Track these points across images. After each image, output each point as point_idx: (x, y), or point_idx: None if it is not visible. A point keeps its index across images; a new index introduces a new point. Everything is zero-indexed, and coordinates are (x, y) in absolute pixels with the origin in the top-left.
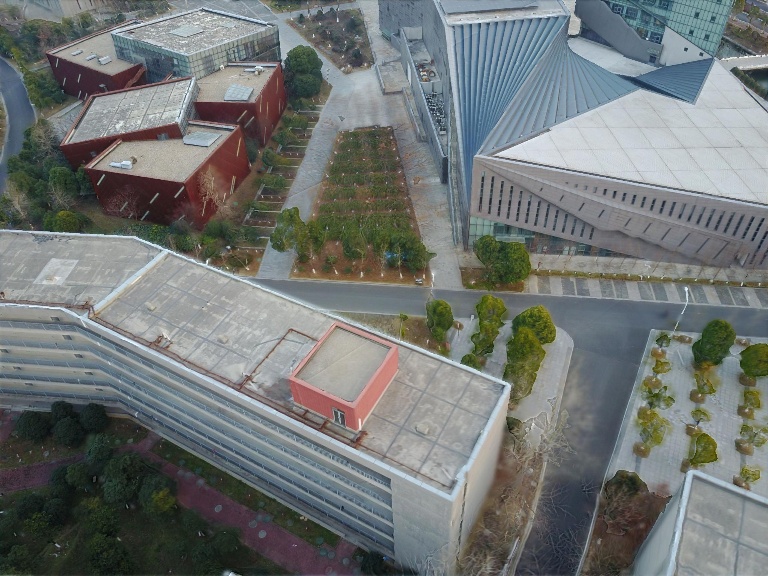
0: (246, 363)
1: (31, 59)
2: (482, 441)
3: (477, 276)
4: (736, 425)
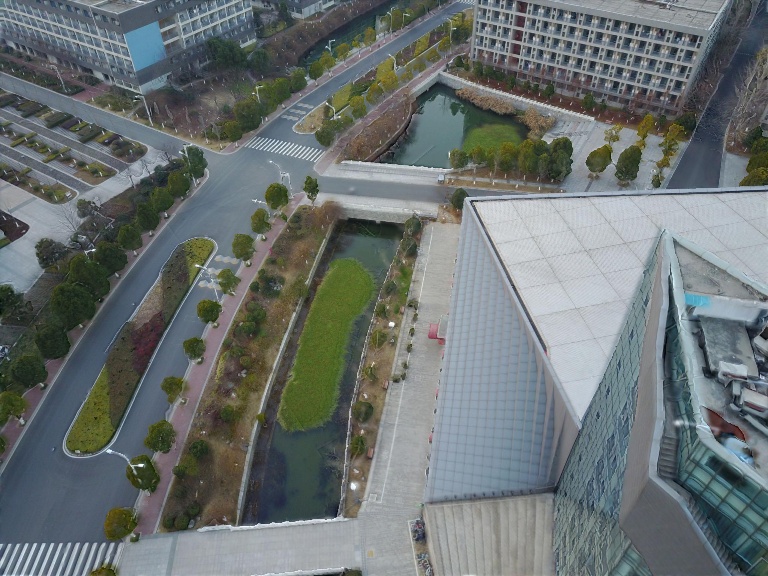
0: None
1: None
2: None
3: None
4: None
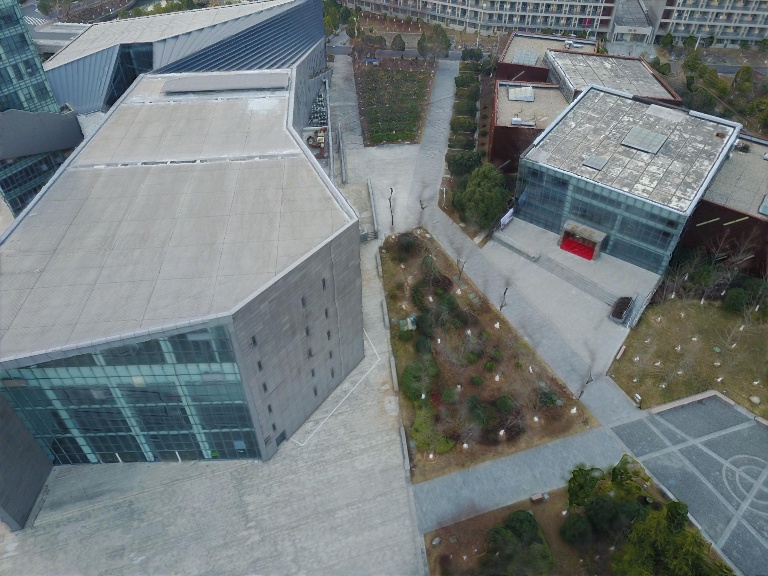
0: None
1: None
2: None
3: None
4: None
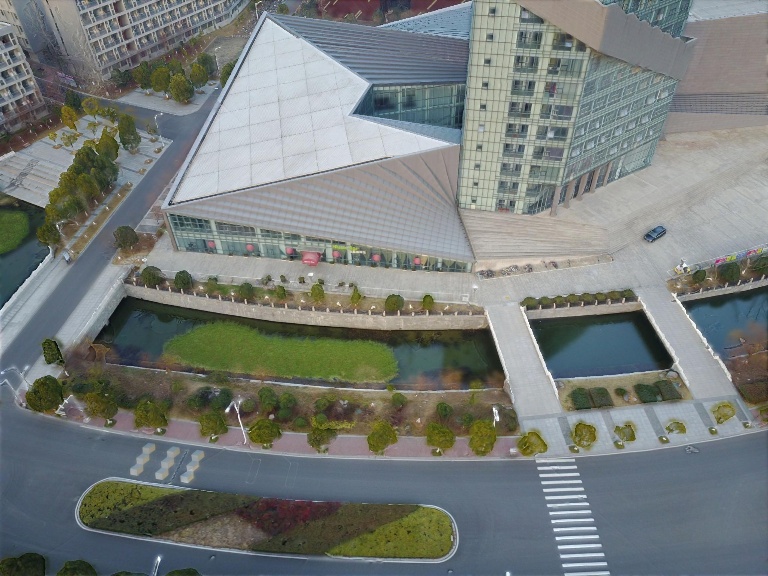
0: None
1: None
2: None
3: None
4: None
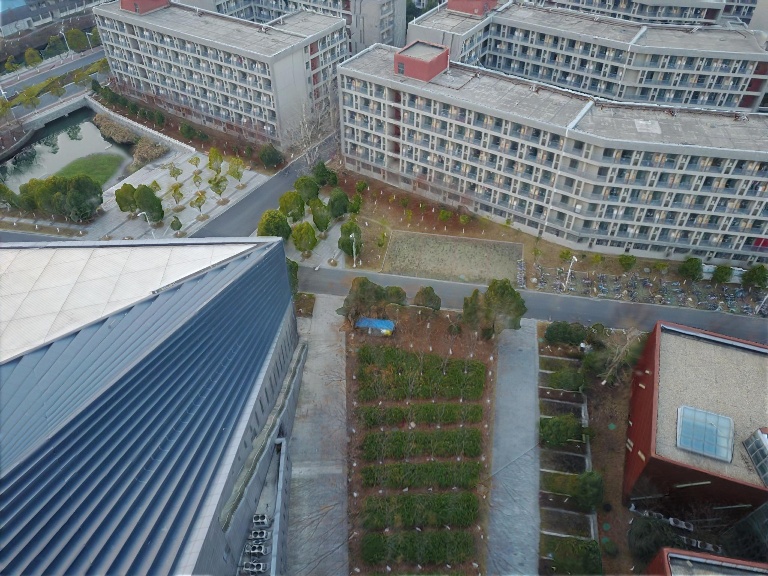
0: (480, 82)
1: None
2: (359, 53)
3: (297, 306)
4: (171, 195)
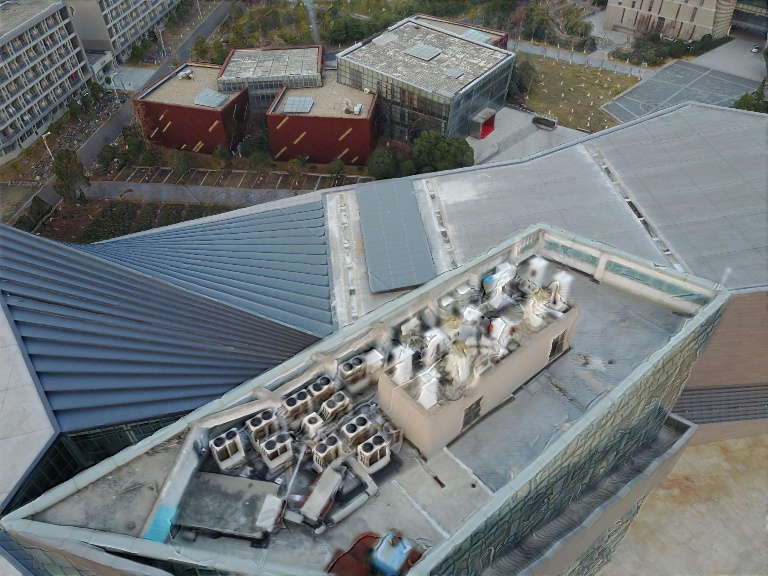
0: None
1: (487, 27)
2: None
3: None
4: None
